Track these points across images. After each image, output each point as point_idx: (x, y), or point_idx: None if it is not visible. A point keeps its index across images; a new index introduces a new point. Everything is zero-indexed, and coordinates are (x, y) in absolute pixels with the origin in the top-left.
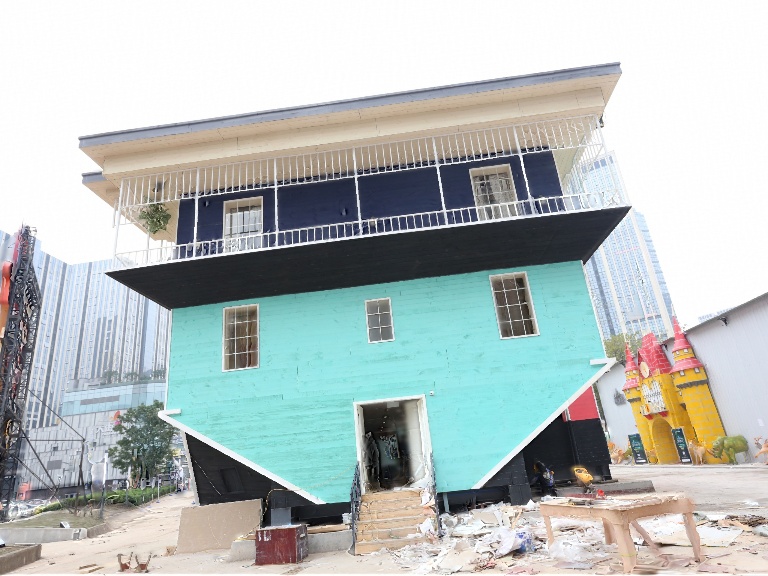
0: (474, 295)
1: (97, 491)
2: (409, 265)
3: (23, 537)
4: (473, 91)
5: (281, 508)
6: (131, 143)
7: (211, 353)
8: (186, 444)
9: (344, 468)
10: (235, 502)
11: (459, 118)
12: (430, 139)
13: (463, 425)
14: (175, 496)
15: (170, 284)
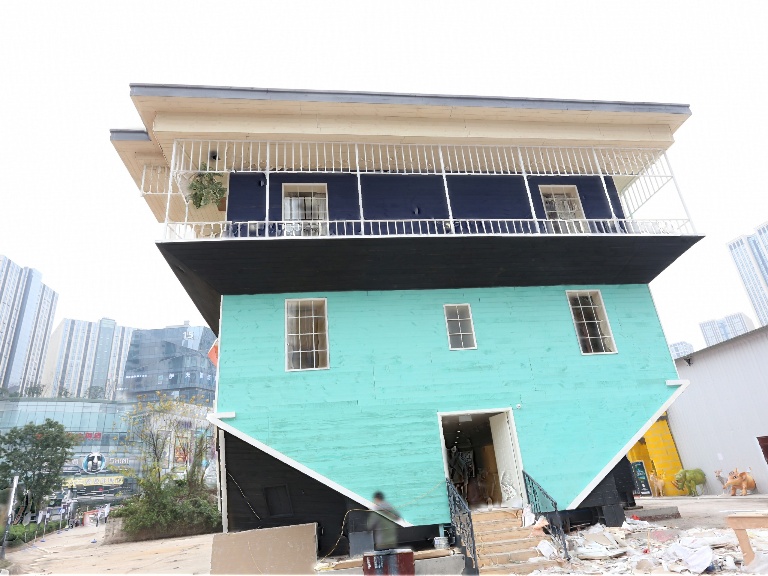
0: (553, 308)
1: (0, 524)
2: (493, 271)
3: None
4: (564, 108)
5: (361, 532)
6: (195, 100)
7: (271, 349)
8: (223, 456)
9: (431, 486)
10: (283, 527)
11: (546, 132)
12: (515, 148)
13: (552, 441)
14: (65, 534)
15: (230, 265)
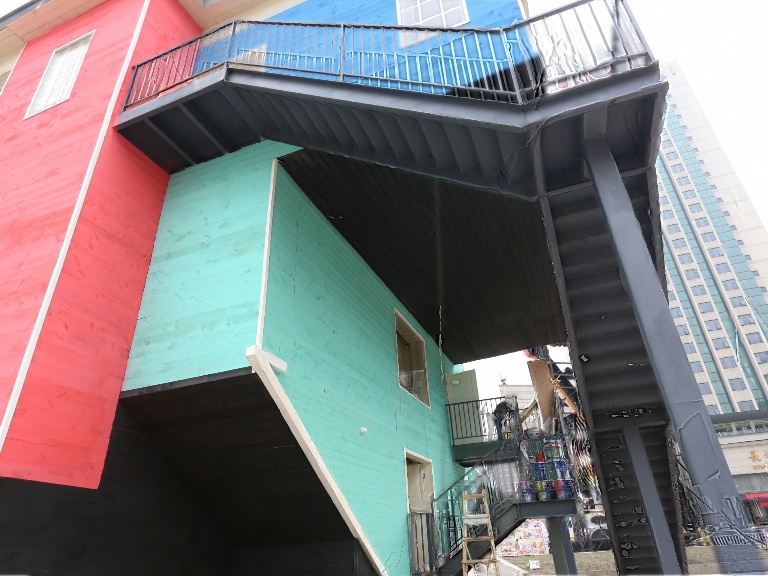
0: None
1: None
2: None
3: (503, 571)
4: None
5: None
6: None
7: None
8: None
9: None
10: None
11: None
12: None
13: None
14: None
15: None
